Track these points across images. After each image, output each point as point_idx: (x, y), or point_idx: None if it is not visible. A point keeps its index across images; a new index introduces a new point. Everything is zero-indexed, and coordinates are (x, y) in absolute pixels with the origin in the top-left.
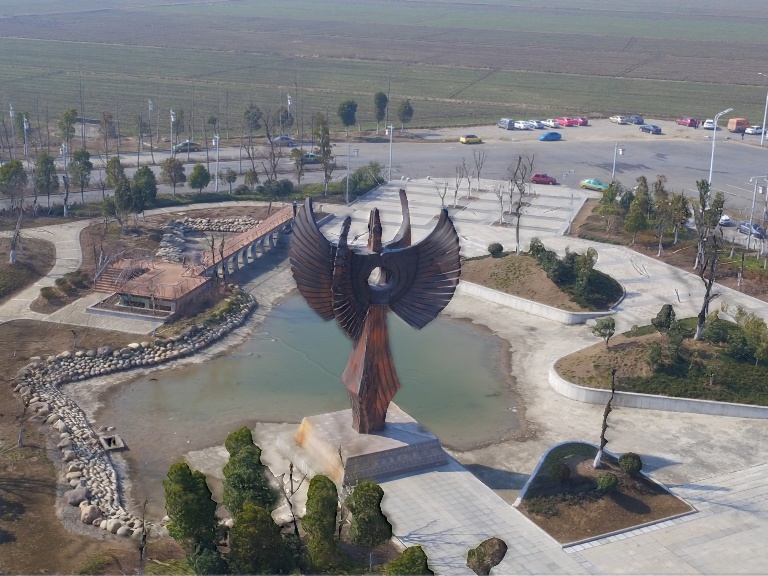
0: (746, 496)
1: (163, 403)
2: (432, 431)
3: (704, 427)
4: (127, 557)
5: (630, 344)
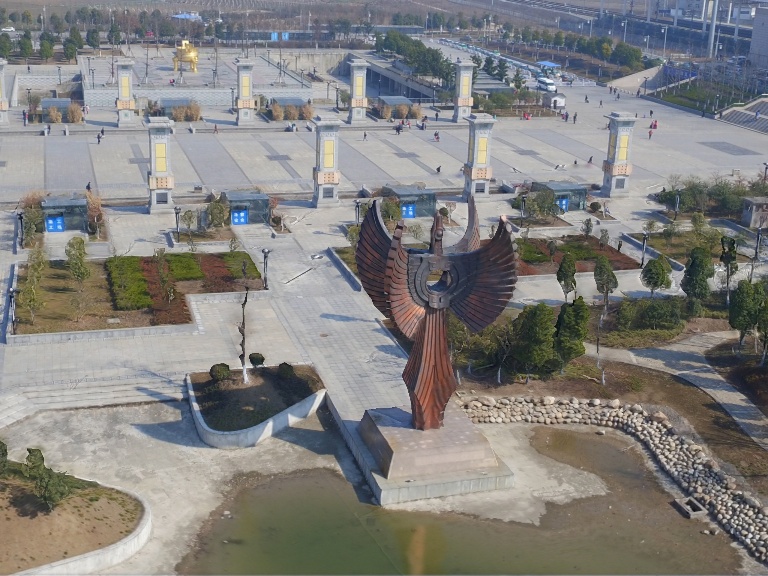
0: (133, 380)
1: (665, 569)
2: (343, 495)
3: (49, 458)
4: (614, 379)
5: (25, 498)
